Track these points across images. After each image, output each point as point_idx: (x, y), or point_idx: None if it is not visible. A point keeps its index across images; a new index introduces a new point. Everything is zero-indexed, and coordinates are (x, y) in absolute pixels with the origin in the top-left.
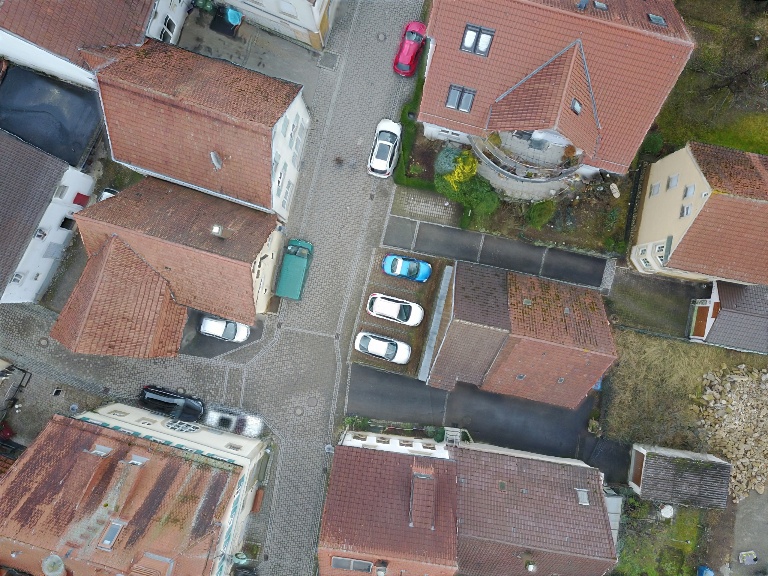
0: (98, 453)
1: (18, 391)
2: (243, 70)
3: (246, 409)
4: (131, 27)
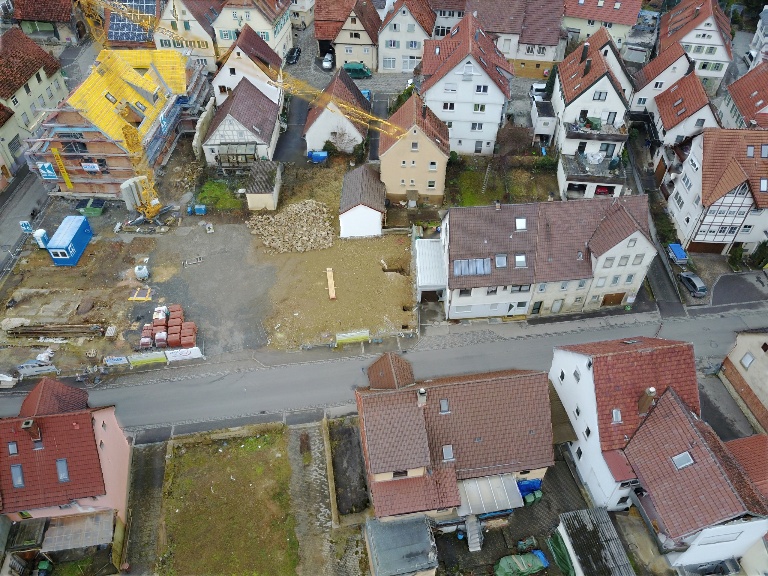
0: (279, 1)
1: (296, 29)
2: None
3: (292, 73)
4: (437, 4)
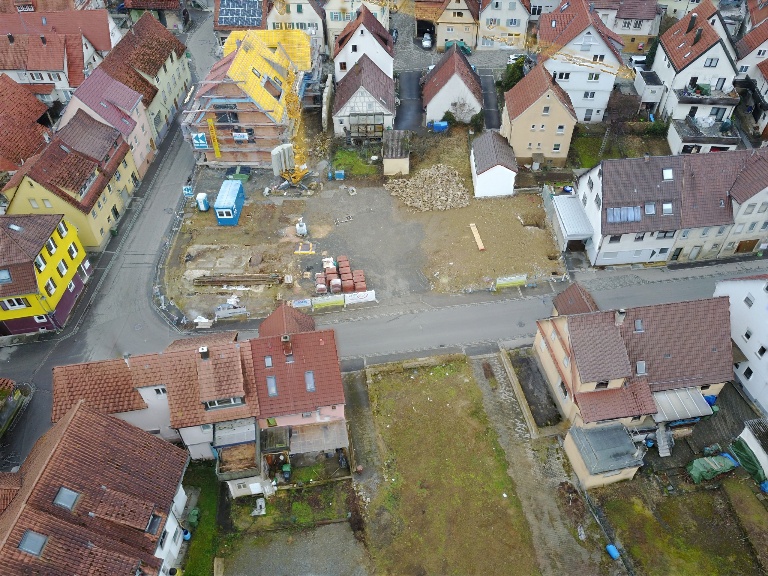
0: None
1: None
2: (529, 6)
3: None
4: None
